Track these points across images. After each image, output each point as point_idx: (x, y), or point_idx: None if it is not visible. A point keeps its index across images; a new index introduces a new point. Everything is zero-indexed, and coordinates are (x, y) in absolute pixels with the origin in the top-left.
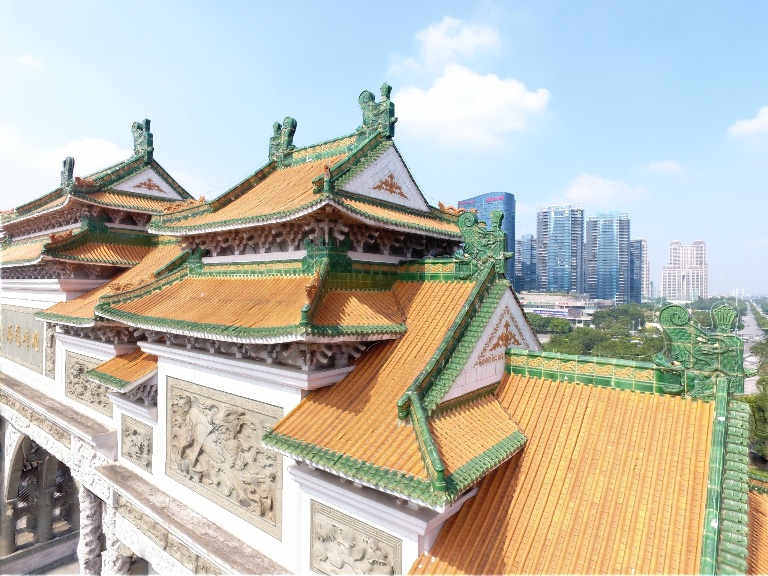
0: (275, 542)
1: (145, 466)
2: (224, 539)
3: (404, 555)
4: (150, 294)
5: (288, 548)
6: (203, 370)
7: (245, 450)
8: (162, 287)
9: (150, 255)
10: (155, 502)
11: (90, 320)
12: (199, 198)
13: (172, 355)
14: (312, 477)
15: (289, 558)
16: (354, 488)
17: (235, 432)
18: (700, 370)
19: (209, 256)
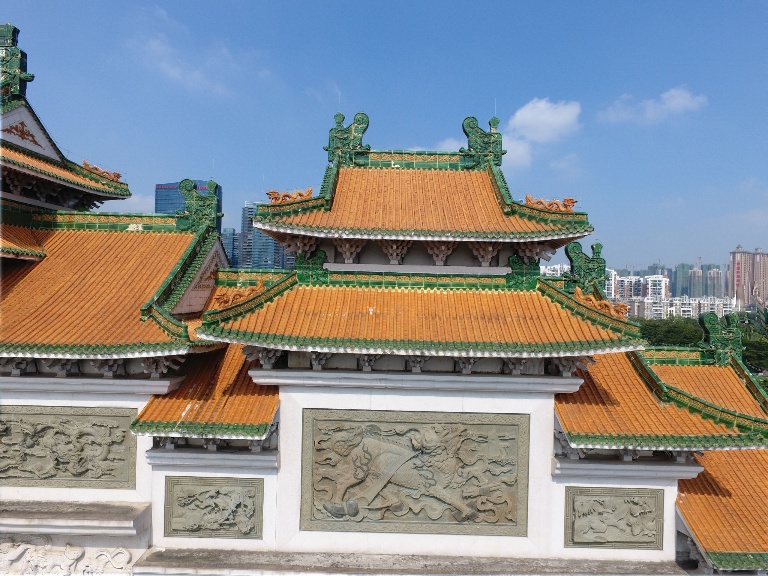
0: (518, 540)
1: (246, 532)
2: (449, 562)
3: (666, 499)
4: (262, 307)
5: (537, 539)
6: (390, 393)
7: (468, 465)
8: (273, 298)
9: (56, 242)
10: (313, 564)
11: (173, 347)
12: (307, 190)
13: (338, 381)
14: (589, 465)
15: (538, 547)
16: (629, 462)
17: (455, 450)
18: (723, 349)
19: (335, 262)
